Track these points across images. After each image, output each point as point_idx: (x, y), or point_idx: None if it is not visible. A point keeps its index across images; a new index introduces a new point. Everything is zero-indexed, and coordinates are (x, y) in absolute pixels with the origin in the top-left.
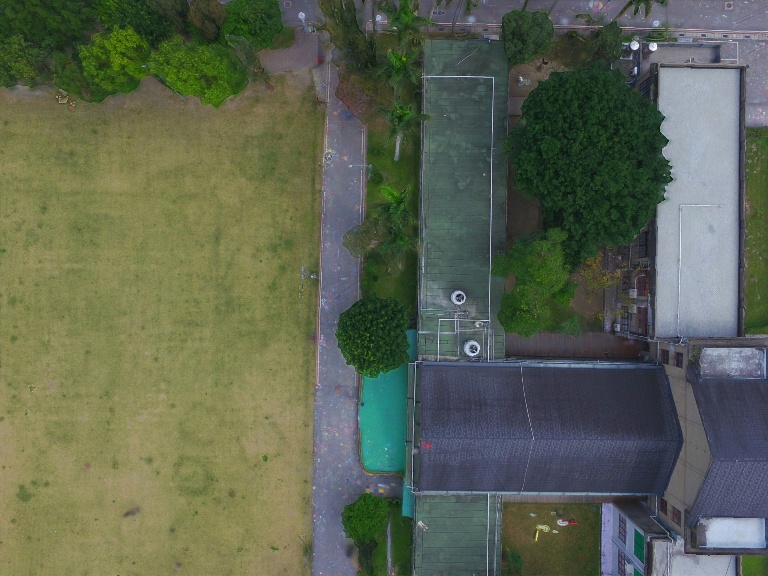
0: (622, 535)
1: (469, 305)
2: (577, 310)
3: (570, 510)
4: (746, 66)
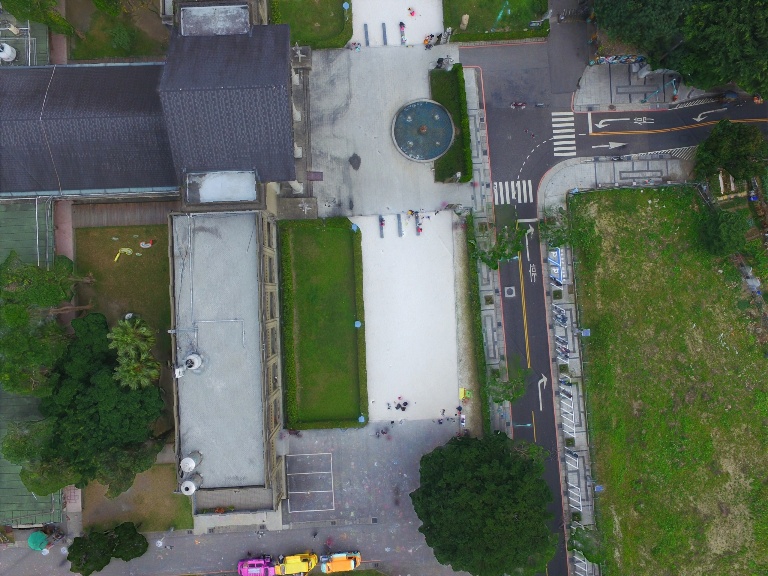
0: None
1: (10, 15)
2: (150, 35)
3: (153, 232)
4: None
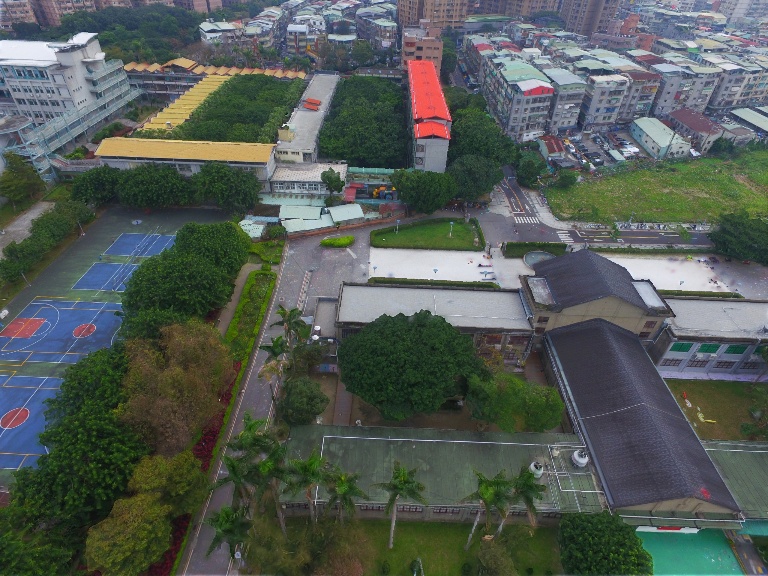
0: (676, 363)
1: None
2: None
3: None
4: (343, 282)
